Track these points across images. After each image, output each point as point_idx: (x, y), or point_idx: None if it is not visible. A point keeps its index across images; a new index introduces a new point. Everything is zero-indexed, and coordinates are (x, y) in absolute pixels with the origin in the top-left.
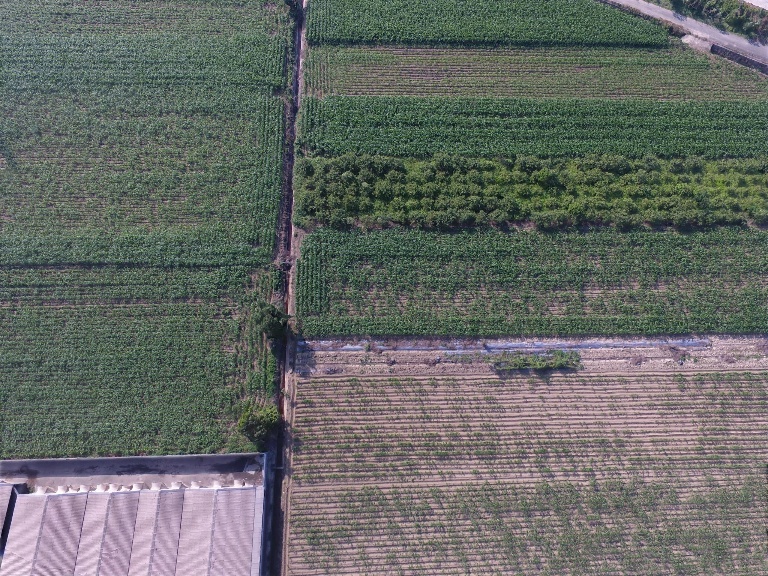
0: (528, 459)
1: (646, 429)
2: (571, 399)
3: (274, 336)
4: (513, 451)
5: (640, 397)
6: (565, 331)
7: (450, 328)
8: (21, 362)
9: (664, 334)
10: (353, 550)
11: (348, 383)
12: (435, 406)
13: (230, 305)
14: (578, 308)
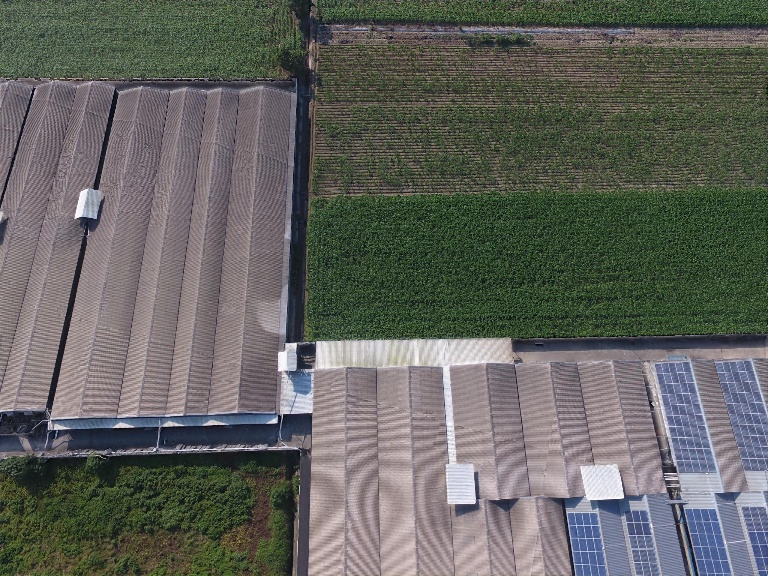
0: (492, 94)
1: (581, 79)
2: (525, 62)
3: (301, 16)
4: (481, 89)
5: (578, 62)
6: (522, 20)
7: (434, 16)
8: (112, 29)
9: (598, 26)
10: (362, 141)
11: (357, 49)
12: (422, 62)
13: (266, 2)
14: (533, 7)
